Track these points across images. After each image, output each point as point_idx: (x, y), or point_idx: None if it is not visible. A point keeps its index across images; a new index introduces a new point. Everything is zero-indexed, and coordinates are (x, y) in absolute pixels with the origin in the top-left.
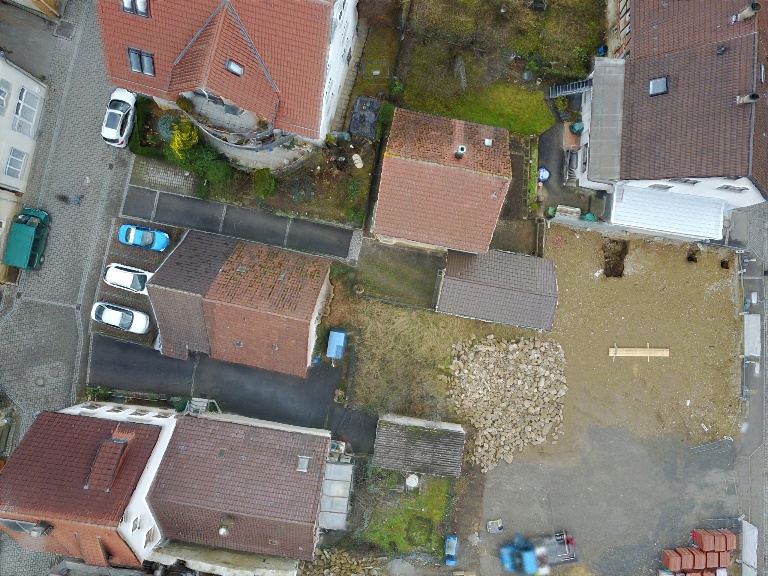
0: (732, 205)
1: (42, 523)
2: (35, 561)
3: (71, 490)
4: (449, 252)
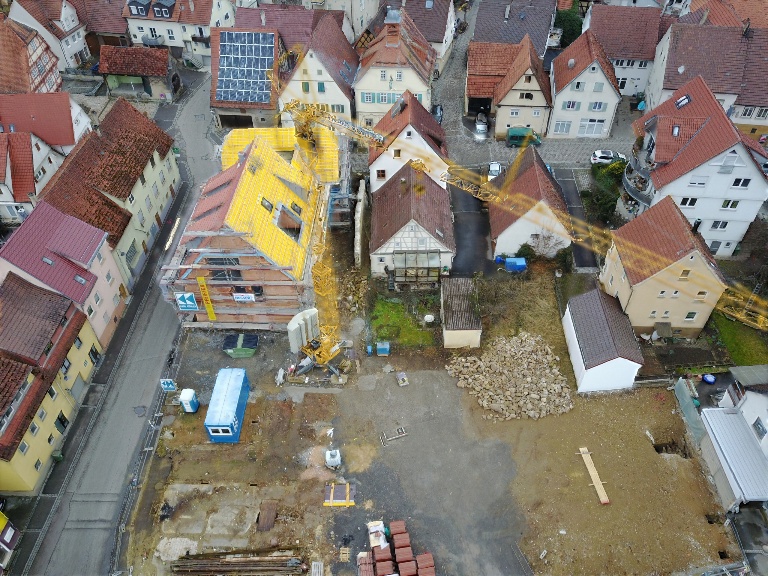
0: None
1: (406, 105)
2: None
3: None
4: None
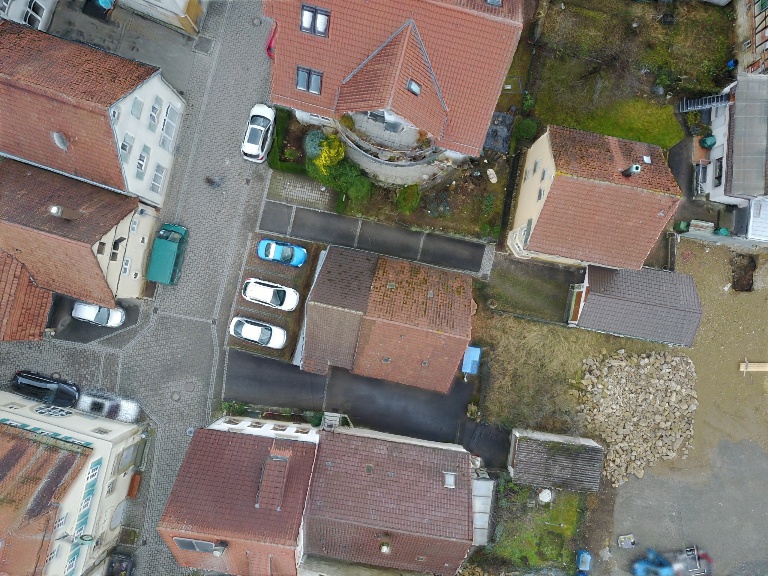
0: None
1: (222, 542)
2: (169, 575)
3: (243, 509)
4: (590, 267)
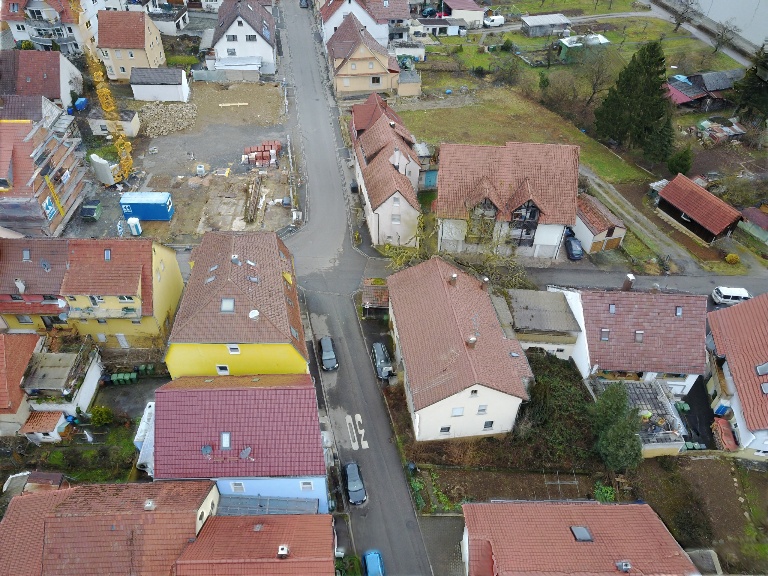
0: (269, 63)
1: None
2: None
3: None
4: None
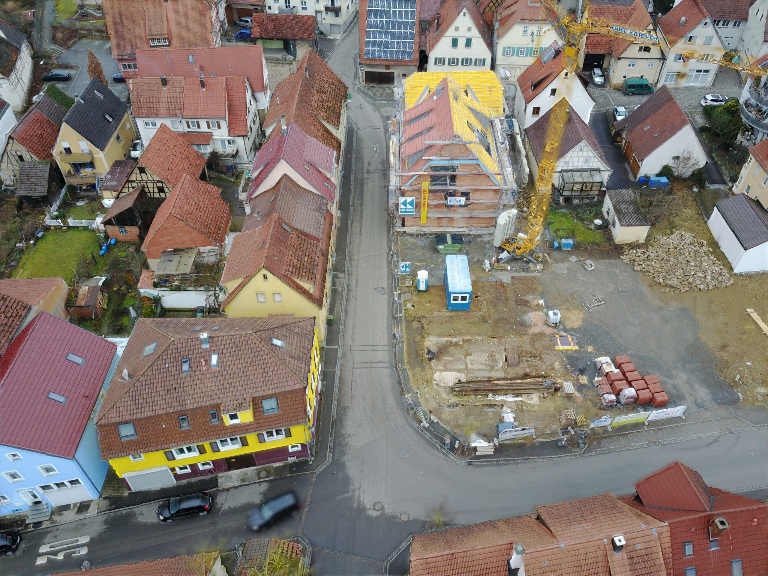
0: None
1: (560, 51)
2: None
3: None
4: (756, 200)
